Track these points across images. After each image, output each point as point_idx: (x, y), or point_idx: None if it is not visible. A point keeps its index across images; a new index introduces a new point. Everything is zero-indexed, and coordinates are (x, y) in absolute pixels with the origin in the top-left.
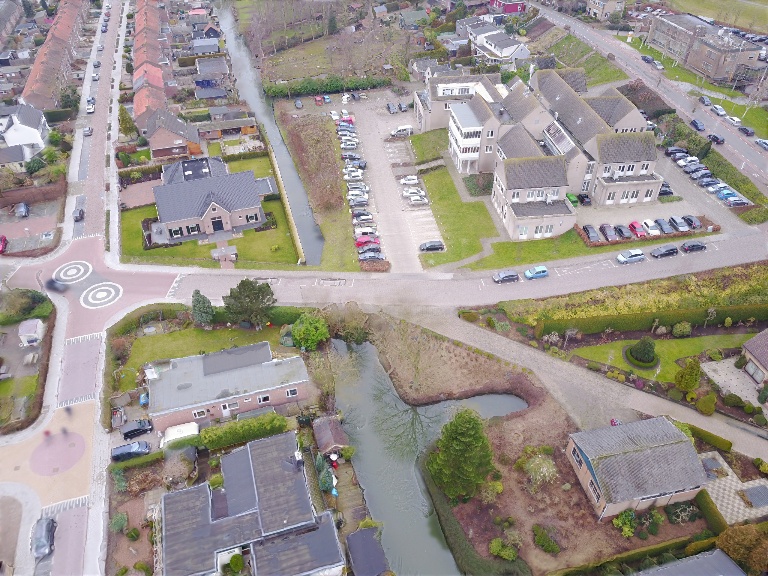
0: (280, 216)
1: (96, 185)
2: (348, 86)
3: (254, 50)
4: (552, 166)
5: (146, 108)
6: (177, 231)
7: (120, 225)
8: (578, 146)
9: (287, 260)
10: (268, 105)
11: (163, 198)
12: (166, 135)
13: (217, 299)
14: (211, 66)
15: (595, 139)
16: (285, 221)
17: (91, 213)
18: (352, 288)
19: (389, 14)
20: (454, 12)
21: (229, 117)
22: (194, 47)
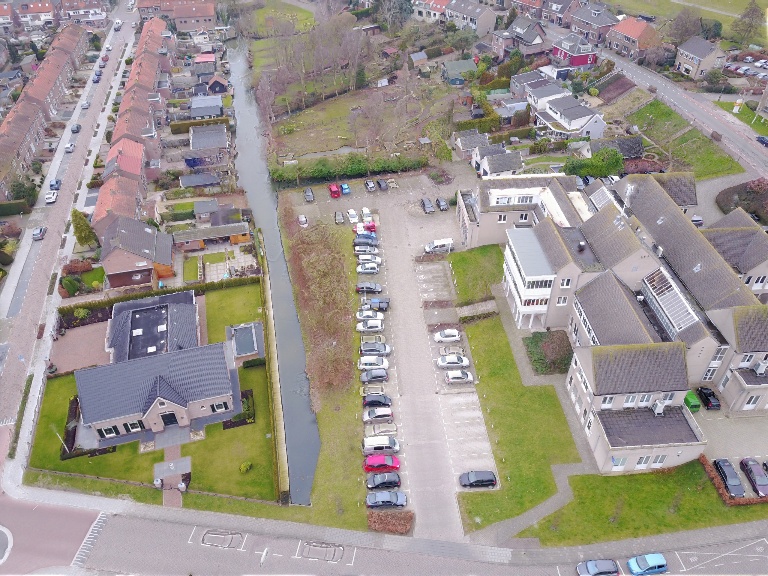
0: (262, 398)
1: (27, 326)
2: (374, 168)
3: (261, 117)
4: (665, 359)
5: (107, 212)
6: (110, 429)
7: (40, 405)
8: (698, 312)
9: (261, 492)
10: (273, 190)
11: (89, 388)
12: (125, 257)
13: (145, 575)
14: (207, 137)
15: (730, 313)
16: (267, 408)
17: (8, 379)
18: (352, 569)
19: (429, 63)
20: (508, 63)
21: (217, 218)
22: (191, 109)
